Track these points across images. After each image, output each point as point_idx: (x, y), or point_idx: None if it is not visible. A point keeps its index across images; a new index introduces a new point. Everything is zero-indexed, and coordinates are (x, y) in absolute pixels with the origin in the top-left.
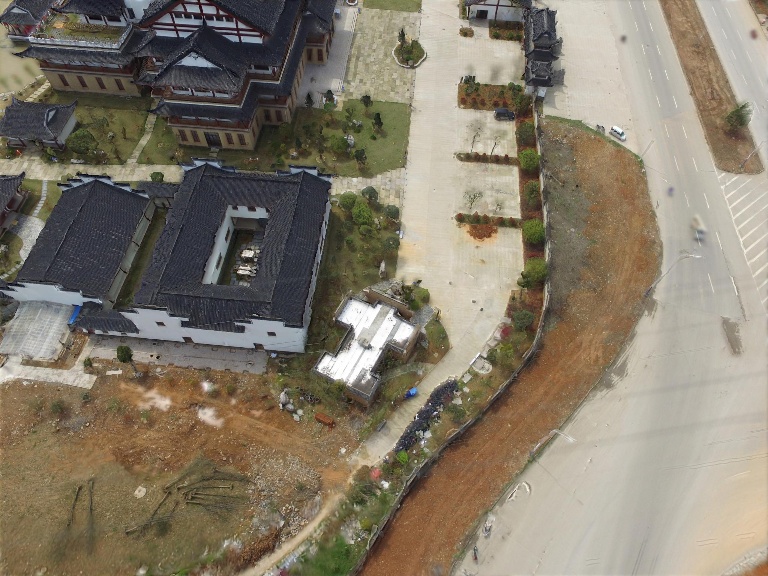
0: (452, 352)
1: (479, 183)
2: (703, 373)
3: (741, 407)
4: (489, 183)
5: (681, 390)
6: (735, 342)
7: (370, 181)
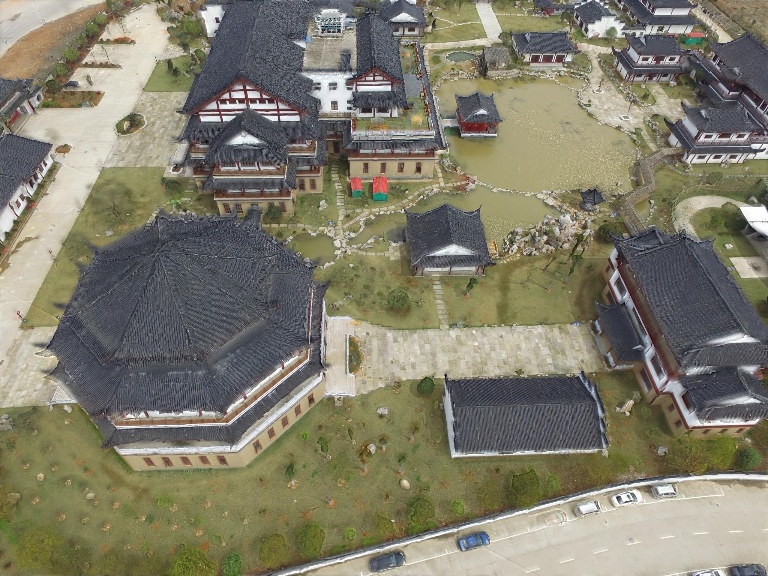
0: (156, 8)
1: (113, 56)
2: (44, 8)
3: (36, 2)
4: (106, 57)
5: (59, 5)
6: (18, 15)
7: (184, 54)
